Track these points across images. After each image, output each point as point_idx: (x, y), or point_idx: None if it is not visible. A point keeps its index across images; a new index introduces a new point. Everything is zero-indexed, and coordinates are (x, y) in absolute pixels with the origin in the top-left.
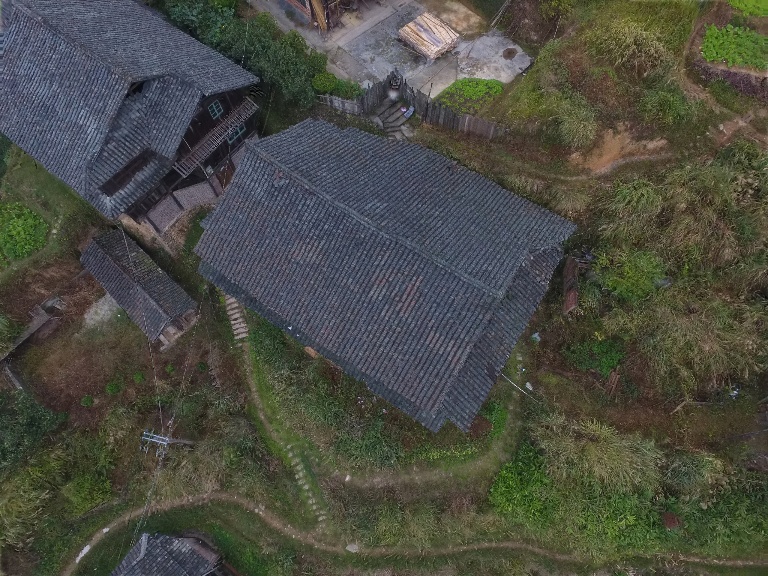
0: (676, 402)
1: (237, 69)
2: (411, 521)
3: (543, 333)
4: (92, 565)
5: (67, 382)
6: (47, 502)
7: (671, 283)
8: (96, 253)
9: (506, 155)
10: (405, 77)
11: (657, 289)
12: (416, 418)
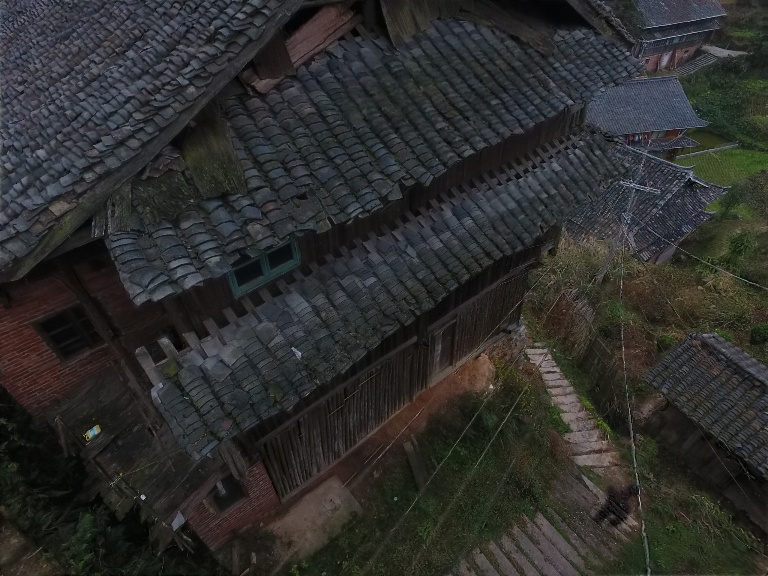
0: None
1: None
2: None
3: None
4: None
5: None
6: None
7: None
8: None
9: None
10: None
11: None
12: None
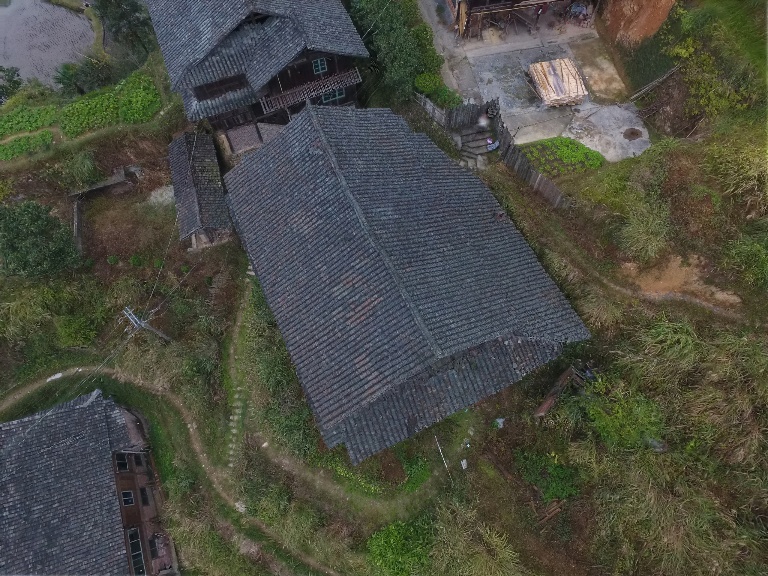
0: (603, 573)
1: (355, 38)
2: (290, 516)
3: (508, 422)
4: (56, 390)
5: (109, 237)
6: (46, 321)
7: (665, 450)
8: (181, 145)
9: (561, 230)
10: (510, 111)
11: (646, 447)
12: (319, 424)
